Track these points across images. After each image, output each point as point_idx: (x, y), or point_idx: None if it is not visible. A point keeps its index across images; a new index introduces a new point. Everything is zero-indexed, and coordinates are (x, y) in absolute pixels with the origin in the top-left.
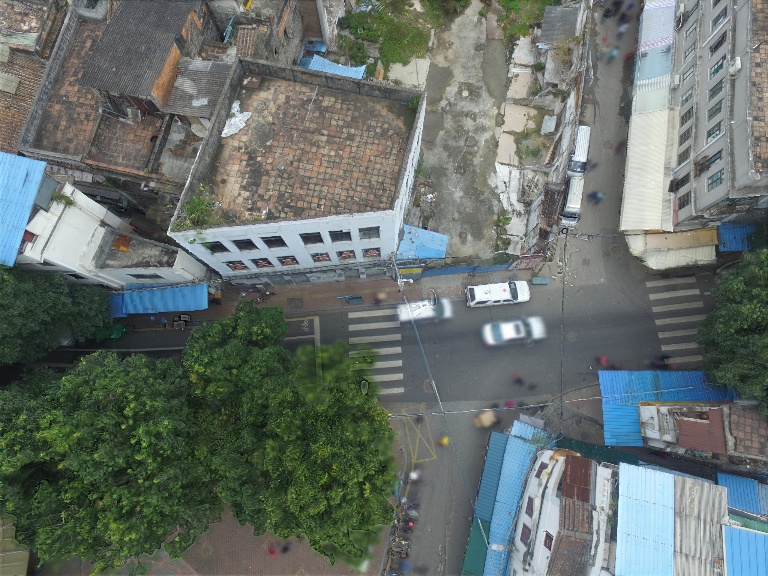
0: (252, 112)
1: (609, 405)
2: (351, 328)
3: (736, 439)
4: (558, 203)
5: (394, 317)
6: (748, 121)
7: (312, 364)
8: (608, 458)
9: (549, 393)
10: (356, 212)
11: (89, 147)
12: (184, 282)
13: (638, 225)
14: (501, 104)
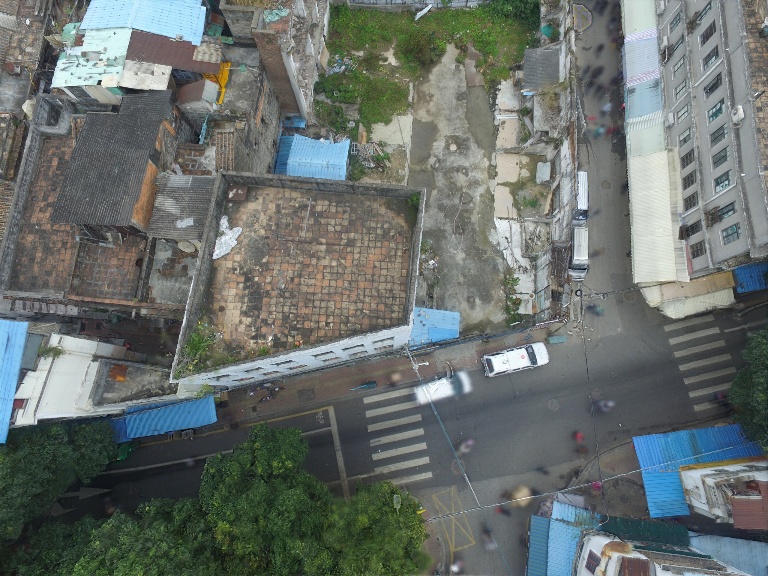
0: (242, 227)
1: (649, 474)
2: (368, 414)
3: None
4: (566, 260)
5: (411, 396)
6: (761, 176)
7: (333, 458)
8: (657, 533)
9: (581, 457)
10: (370, 332)
11: (70, 280)
12: (189, 398)
13: (652, 277)
14: (491, 154)
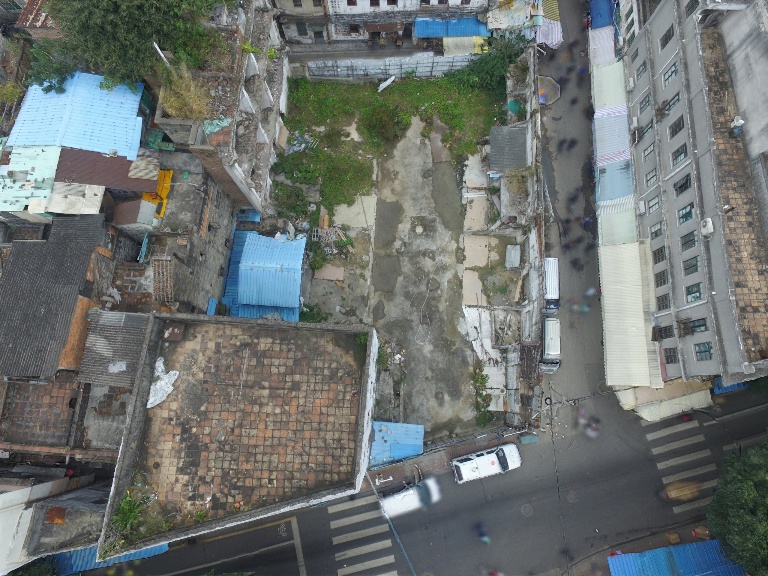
0: (179, 370)
1: None
2: (333, 525)
3: None
4: (536, 360)
5: (378, 504)
6: (732, 301)
7: (296, 575)
8: None
9: (557, 567)
10: (313, 498)
11: None
12: None
13: (625, 380)
14: (459, 236)
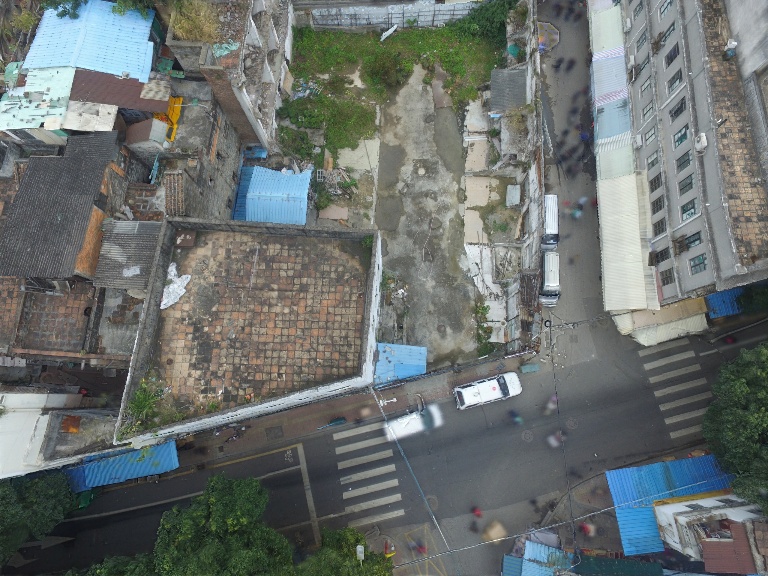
0: (191, 274)
1: (622, 510)
2: (338, 451)
3: (765, 558)
4: (536, 288)
5: (382, 431)
6: (725, 207)
7: (302, 498)
8: (631, 573)
9: (557, 490)
10: (321, 385)
11: (16, 332)
12: (148, 445)
13: (623, 304)
14: (460, 178)
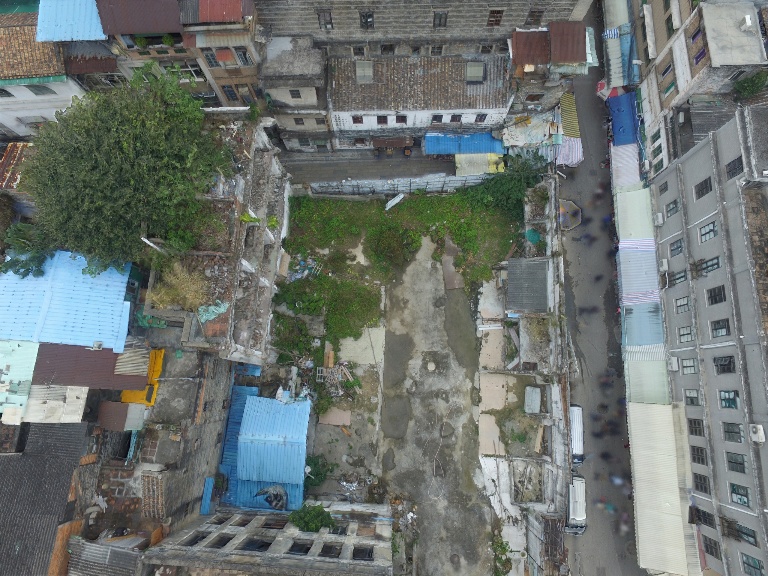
0: None
1: None
2: None
3: None
4: (561, 533)
5: None
6: None
7: None
8: None
9: None
10: None
11: None
12: None
13: (660, 564)
14: (474, 374)
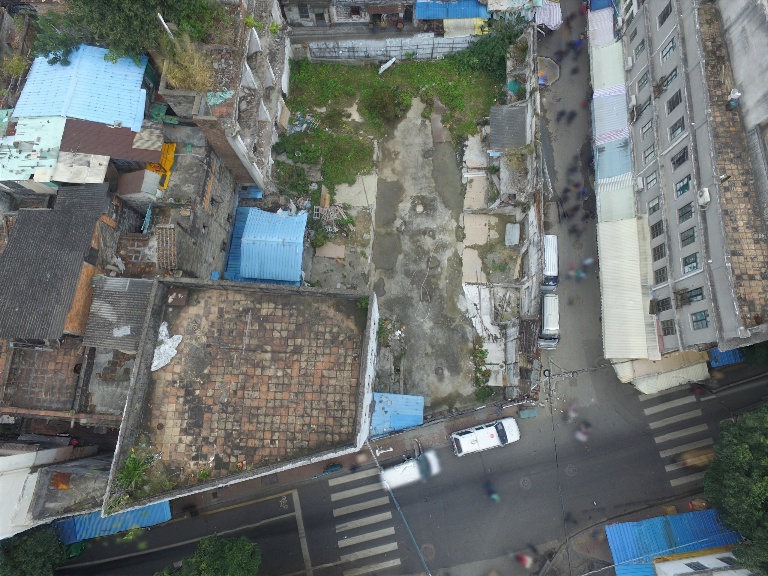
0: (183, 334)
1: (622, 566)
2: (334, 498)
3: None
4: (535, 334)
5: (378, 477)
6: (728, 267)
7: (297, 547)
8: None
9: (555, 539)
10: (314, 456)
11: (4, 391)
12: None
13: (623, 353)
14: (459, 215)
